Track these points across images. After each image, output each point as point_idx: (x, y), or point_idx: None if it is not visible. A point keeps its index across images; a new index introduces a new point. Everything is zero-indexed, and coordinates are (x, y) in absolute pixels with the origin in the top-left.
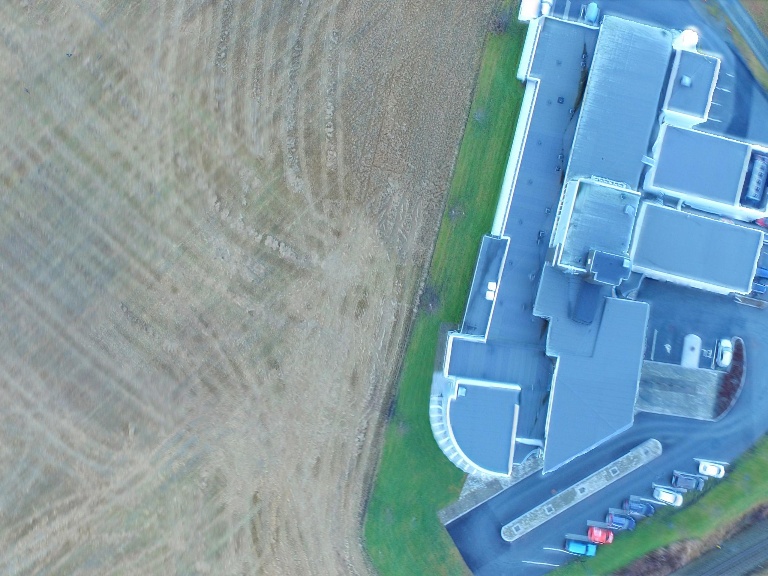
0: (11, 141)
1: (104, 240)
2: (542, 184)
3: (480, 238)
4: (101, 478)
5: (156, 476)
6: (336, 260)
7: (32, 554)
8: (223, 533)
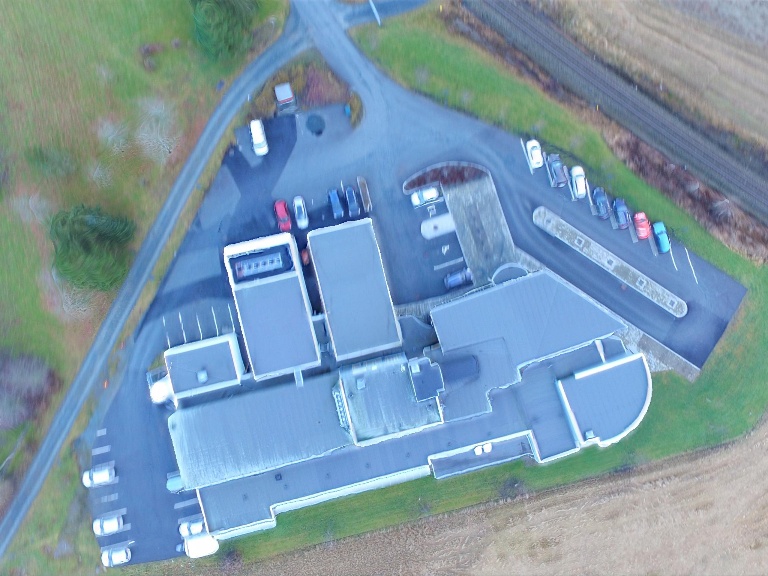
0: None
1: None
2: (364, 454)
3: None
4: None
5: None
6: None
7: None
8: None
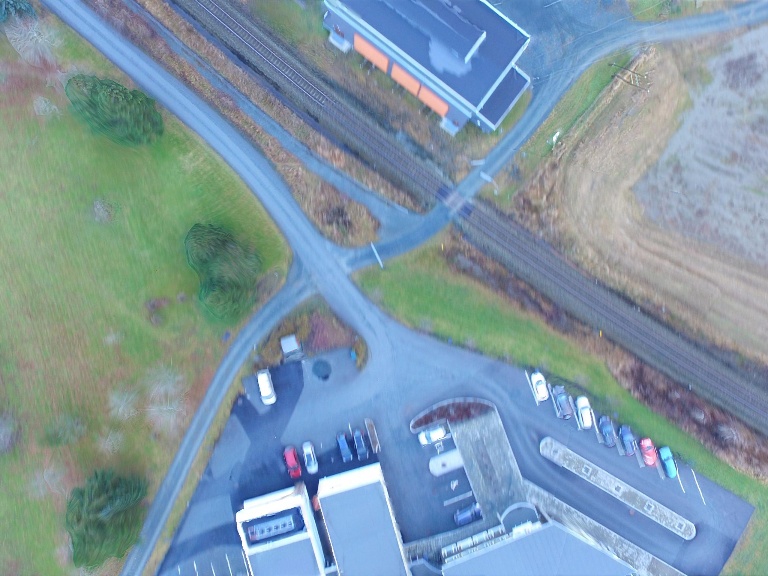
0: None
1: None
2: None
3: None
4: None
5: None
6: None
7: None
8: None
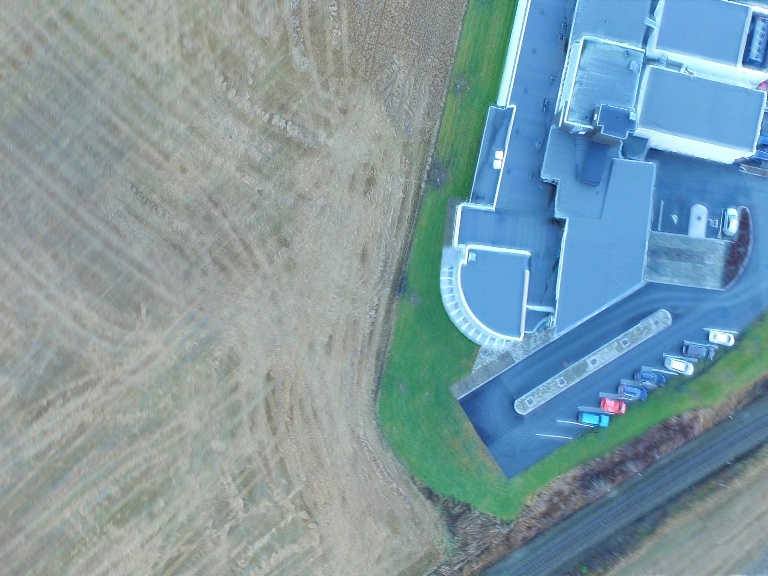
0: (17, 23)
1: (112, 121)
2: (546, 53)
3: (486, 111)
4: (114, 359)
5: (169, 356)
6: (343, 138)
7: (47, 436)
8: (237, 412)
